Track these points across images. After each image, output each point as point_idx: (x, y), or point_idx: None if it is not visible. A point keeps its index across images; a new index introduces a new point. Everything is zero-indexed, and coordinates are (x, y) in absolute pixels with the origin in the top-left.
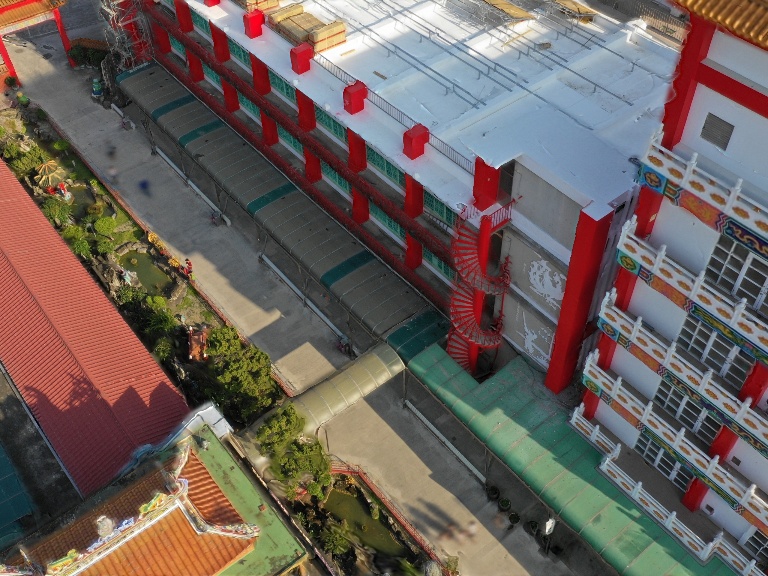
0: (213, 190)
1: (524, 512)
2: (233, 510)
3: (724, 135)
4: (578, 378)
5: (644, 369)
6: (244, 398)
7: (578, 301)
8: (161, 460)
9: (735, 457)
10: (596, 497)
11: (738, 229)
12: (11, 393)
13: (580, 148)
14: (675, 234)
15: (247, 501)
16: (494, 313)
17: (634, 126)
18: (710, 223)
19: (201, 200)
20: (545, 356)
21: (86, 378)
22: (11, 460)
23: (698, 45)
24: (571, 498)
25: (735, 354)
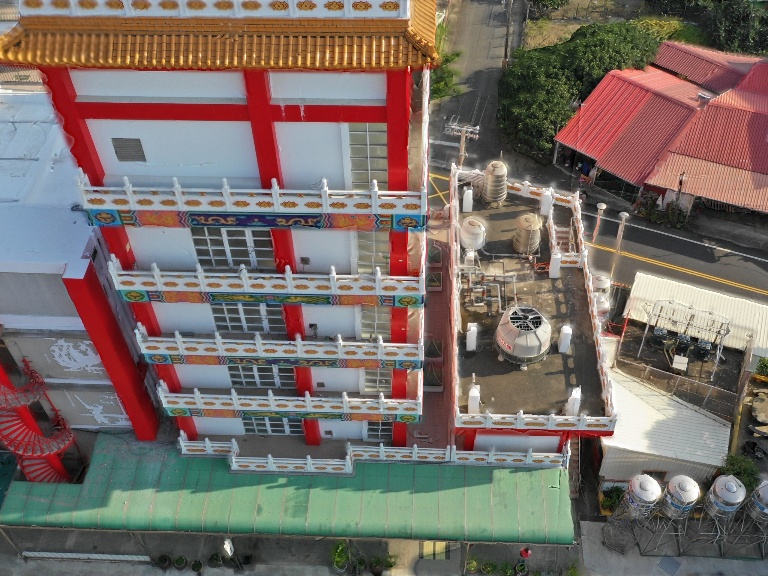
0: None
1: (200, 554)
2: None
3: (136, 150)
4: (162, 414)
5: (208, 368)
6: None
7: (116, 354)
8: None
9: (318, 383)
10: (246, 494)
11: (200, 217)
12: None
13: (20, 225)
14: (155, 249)
15: None
16: (48, 415)
17: (53, 177)
18: (176, 225)
19: None
20: (122, 417)
21: None
22: None
23: (63, 89)
24: (228, 511)
25: (265, 310)
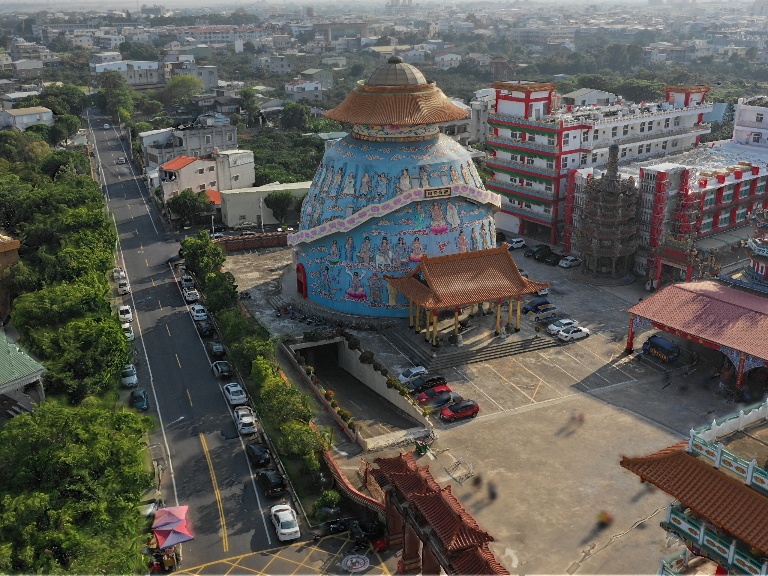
0: (737, 260)
1: None
2: None
3: None
4: None
5: None
6: None
7: None
8: None
9: None
10: None
11: None
12: None
13: None
14: None
15: None
16: None
17: None
18: None
19: (745, 262)
20: None
21: None
22: None
23: None
24: None
25: None
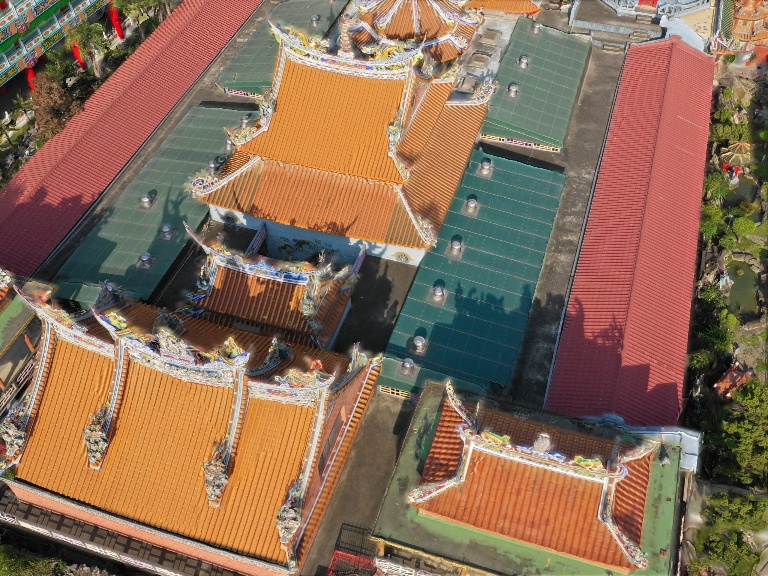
0: None
1: None
2: (640, 529)
3: None
4: None
5: None
6: (730, 457)
7: None
8: (621, 438)
9: None
10: None
11: None
12: (564, 293)
13: None
14: None
15: (657, 535)
16: None
17: None
18: None
19: None
20: None
21: (623, 329)
22: (523, 339)
23: None
24: None
25: None
